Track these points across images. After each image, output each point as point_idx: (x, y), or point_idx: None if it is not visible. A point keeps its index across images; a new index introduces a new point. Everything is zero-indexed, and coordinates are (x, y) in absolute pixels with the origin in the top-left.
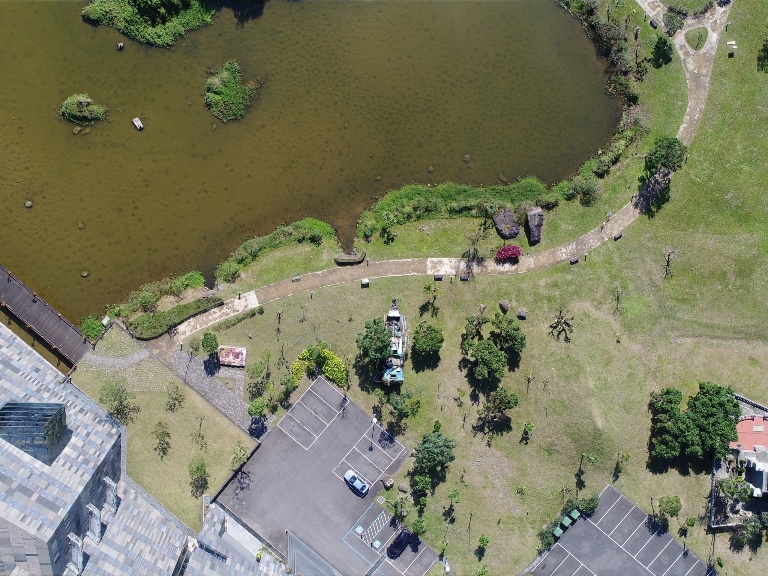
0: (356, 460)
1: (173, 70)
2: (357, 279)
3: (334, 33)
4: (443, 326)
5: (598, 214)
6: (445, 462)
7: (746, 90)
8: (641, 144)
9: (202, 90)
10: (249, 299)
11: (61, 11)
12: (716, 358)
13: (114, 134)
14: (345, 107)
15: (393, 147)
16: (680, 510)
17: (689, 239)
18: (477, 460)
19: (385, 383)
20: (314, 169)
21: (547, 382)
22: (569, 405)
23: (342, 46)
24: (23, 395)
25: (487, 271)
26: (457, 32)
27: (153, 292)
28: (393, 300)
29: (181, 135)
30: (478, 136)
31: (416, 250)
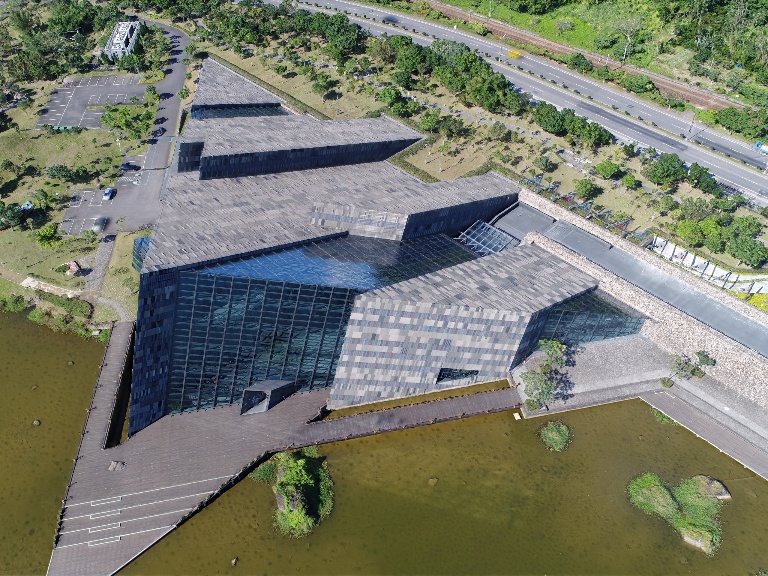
0: (97, 202)
1: None
2: None
3: None
4: None
5: None
6: None
7: None
8: None
9: None
10: (28, 283)
11: None
12: None
13: None
14: None
15: None
16: None
17: None
18: None
19: None
20: None
21: None
22: None
23: None
24: None
25: None
26: None
27: None
28: None
29: None
30: None
31: None
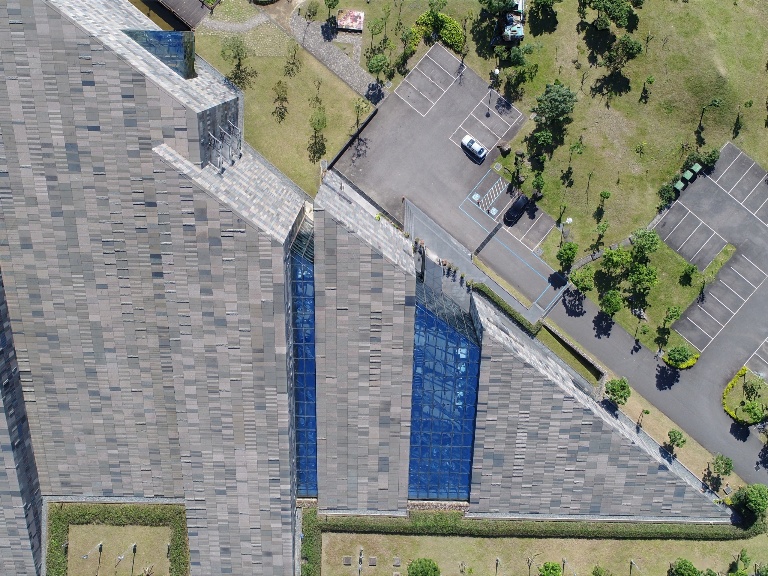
0: (473, 127)
1: None
2: None
3: None
4: None
5: None
6: (563, 125)
7: None
8: None
9: None
10: None
11: None
12: None
13: None
14: None
15: None
16: None
17: None
18: (596, 121)
19: (506, 38)
20: None
21: (666, 40)
22: (690, 59)
23: None
24: None
25: None
26: None
27: None
28: None
29: None
30: None
31: None
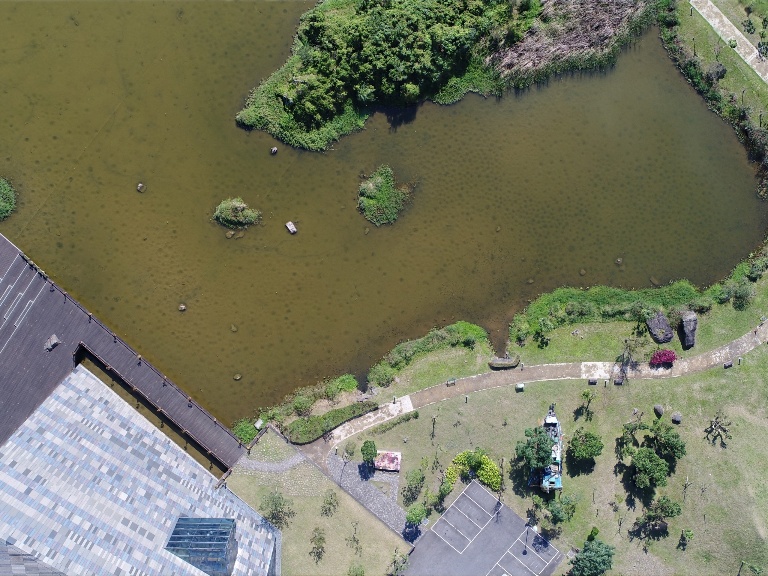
0: (510, 564)
1: (326, 174)
2: (511, 383)
3: (486, 137)
4: (597, 430)
5: (751, 318)
6: None
7: None
8: None
9: (355, 194)
10: (404, 403)
11: (215, 116)
12: None
13: (267, 238)
14: (497, 211)
15: (545, 250)
16: None
17: None
18: (633, 565)
19: (544, 490)
20: (466, 272)
21: (705, 488)
22: (728, 512)
23: (494, 150)
24: (189, 507)
25: (641, 375)
26: (609, 136)
27: (309, 397)
28: (551, 407)
29: (334, 239)
30: (630, 239)
31: (570, 354)
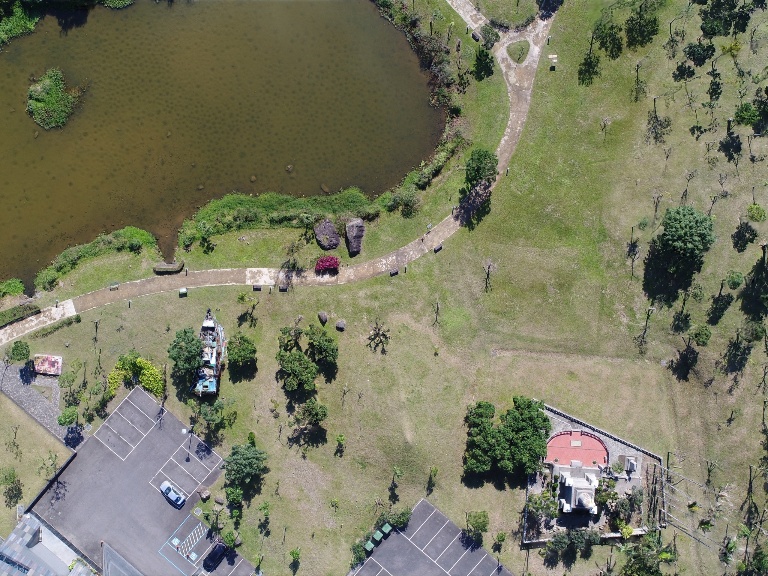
0: (173, 471)
1: None
2: (175, 288)
3: (158, 42)
4: (261, 337)
5: (419, 226)
6: (261, 474)
7: (567, 103)
8: (463, 156)
9: (25, 97)
10: (66, 307)
11: None
12: (535, 372)
13: None
14: (168, 116)
15: (216, 156)
16: (493, 525)
17: (509, 252)
18: (292, 472)
19: (197, 393)
20: (136, 177)
21: (362, 394)
22: (382, 418)
23: (166, 55)
24: None
25: (306, 282)
26: (281, 42)
27: None
28: (207, 310)
29: (3, 142)
30: (301, 146)
31: (235, 260)
